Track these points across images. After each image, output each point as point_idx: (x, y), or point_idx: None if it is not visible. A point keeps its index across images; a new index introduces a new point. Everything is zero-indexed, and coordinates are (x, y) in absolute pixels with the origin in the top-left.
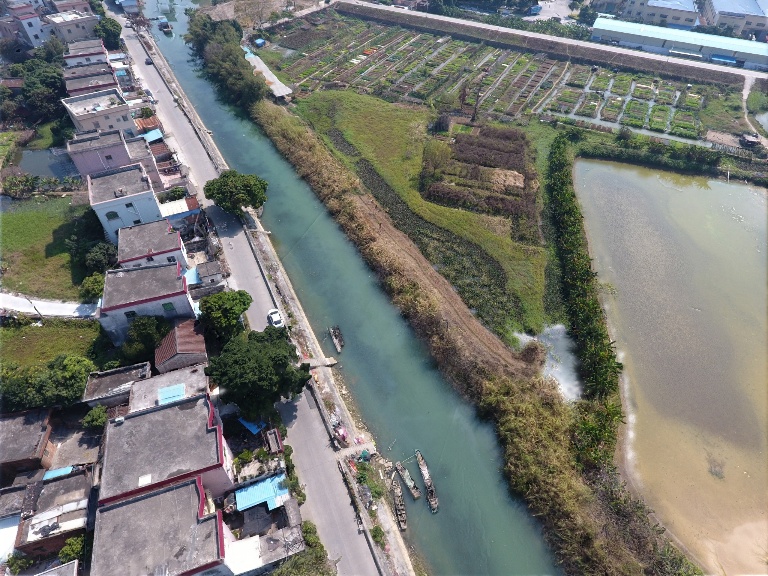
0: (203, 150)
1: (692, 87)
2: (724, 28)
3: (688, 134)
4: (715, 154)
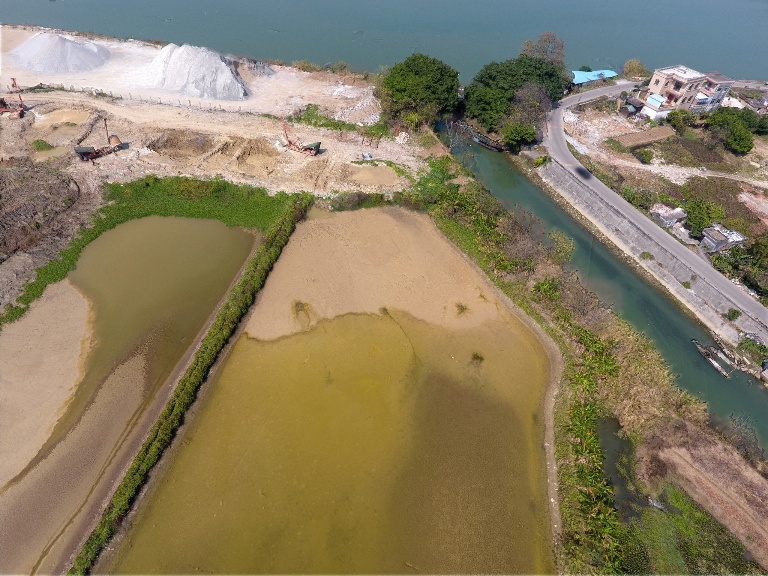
0: None
1: None
2: None
3: None
4: None
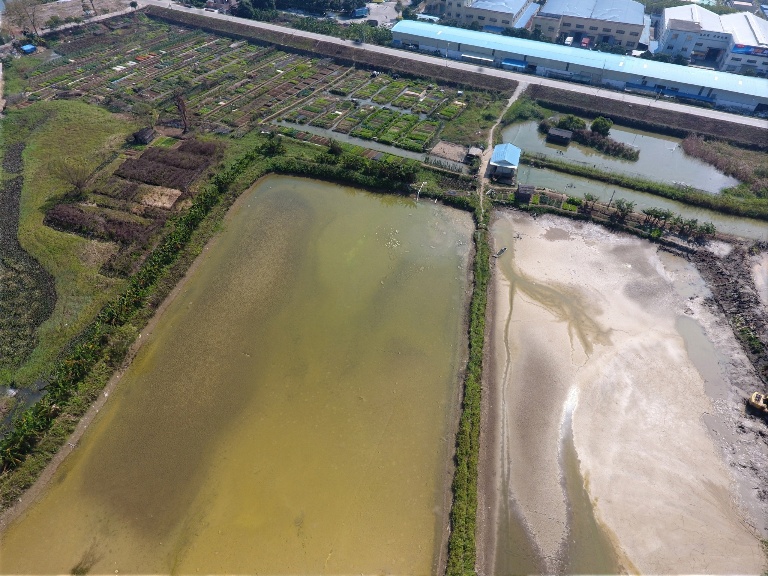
0: None
1: (463, 94)
2: (532, 30)
3: (412, 146)
4: (406, 170)
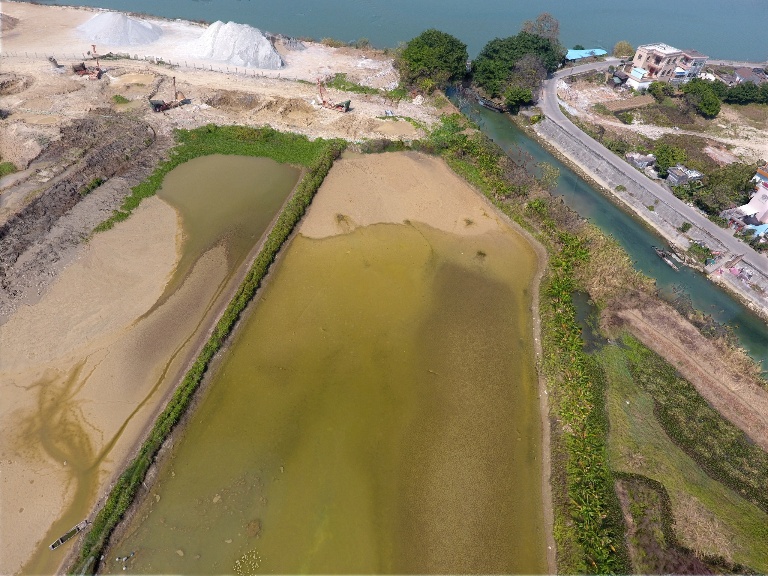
0: None
1: None
2: None
3: None
4: None
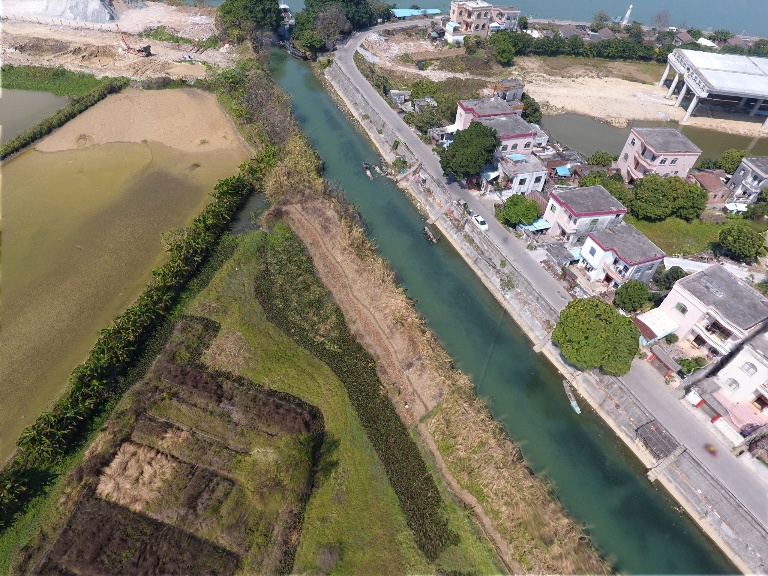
0: (765, 523)
1: None
2: None
3: None
4: None
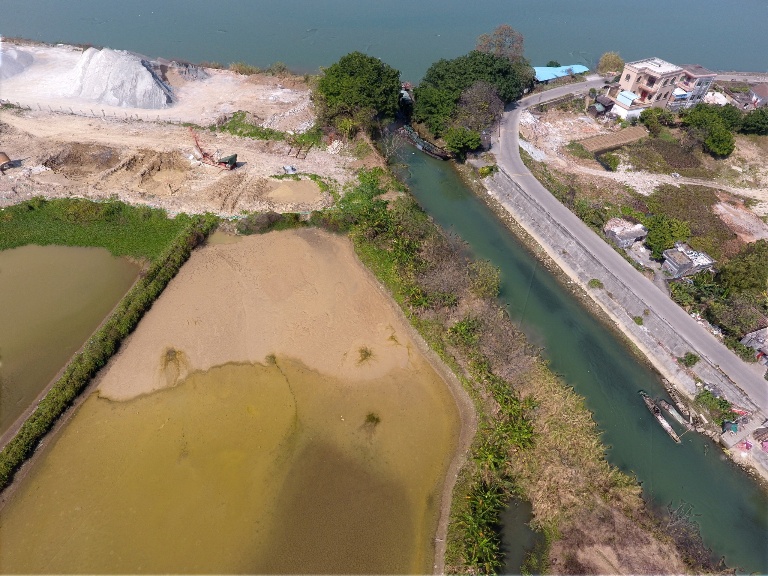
0: None
1: None
2: None
3: None
4: None
